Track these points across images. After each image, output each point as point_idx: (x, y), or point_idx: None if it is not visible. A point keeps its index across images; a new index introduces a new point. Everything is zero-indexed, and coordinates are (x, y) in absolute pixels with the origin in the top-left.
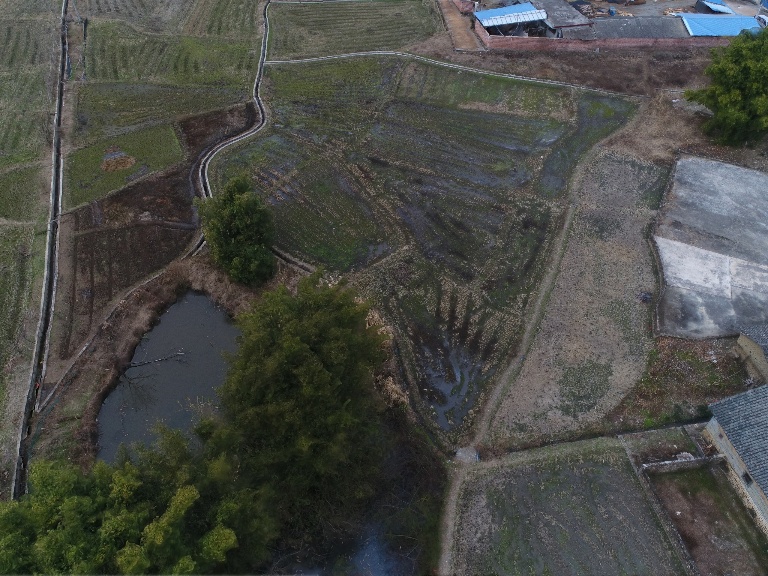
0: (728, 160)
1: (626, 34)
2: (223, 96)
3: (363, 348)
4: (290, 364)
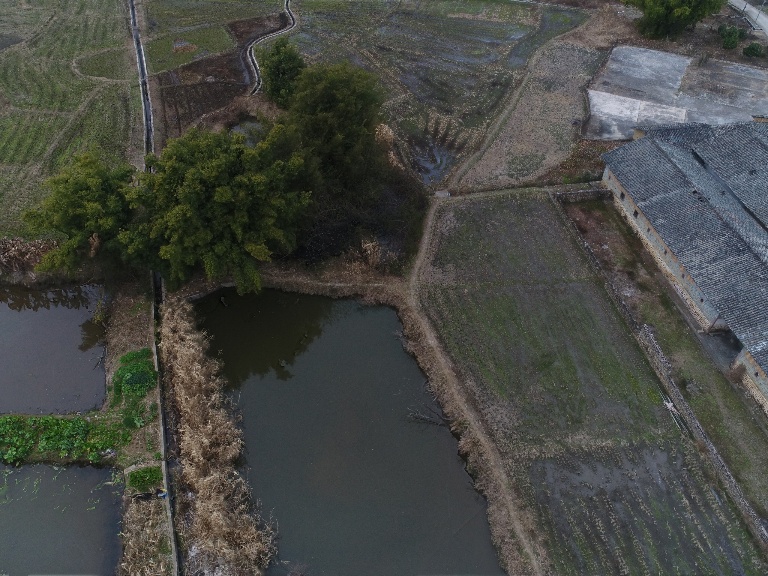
0: (653, 48)
1: None
2: (261, 9)
3: (374, 102)
4: (331, 90)
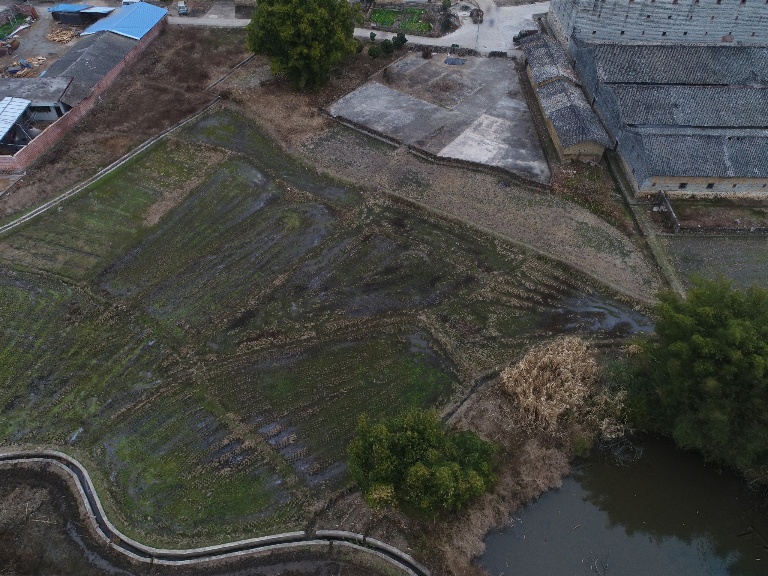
0: None
1: (103, 69)
2: None
3: None
4: None
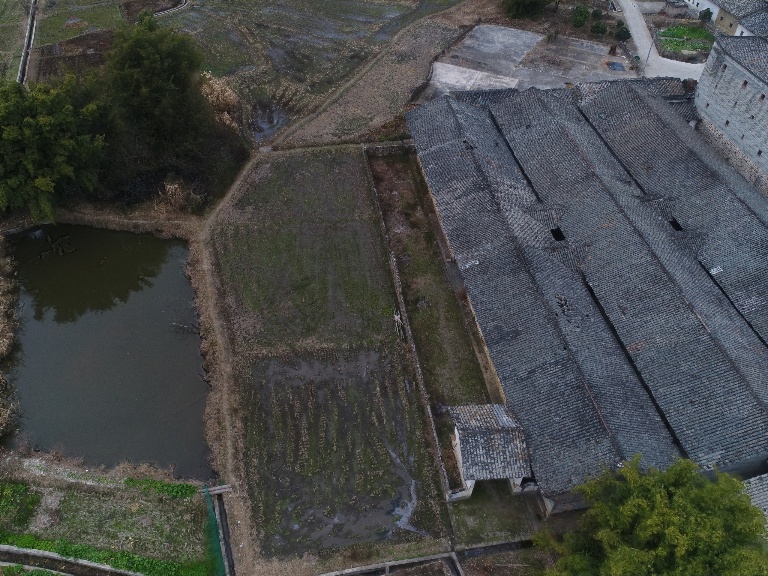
0: None
1: None
2: None
3: (190, 62)
4: None
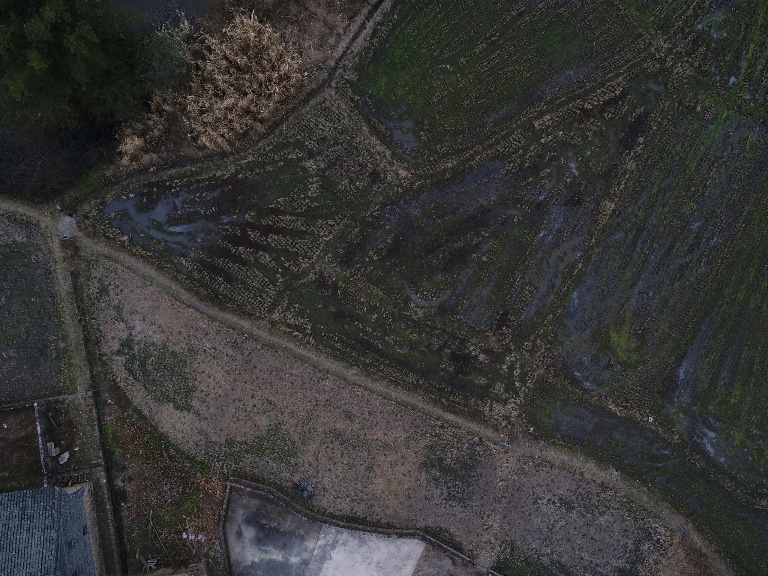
0: None
1: None
2: None
3: None
4: None
